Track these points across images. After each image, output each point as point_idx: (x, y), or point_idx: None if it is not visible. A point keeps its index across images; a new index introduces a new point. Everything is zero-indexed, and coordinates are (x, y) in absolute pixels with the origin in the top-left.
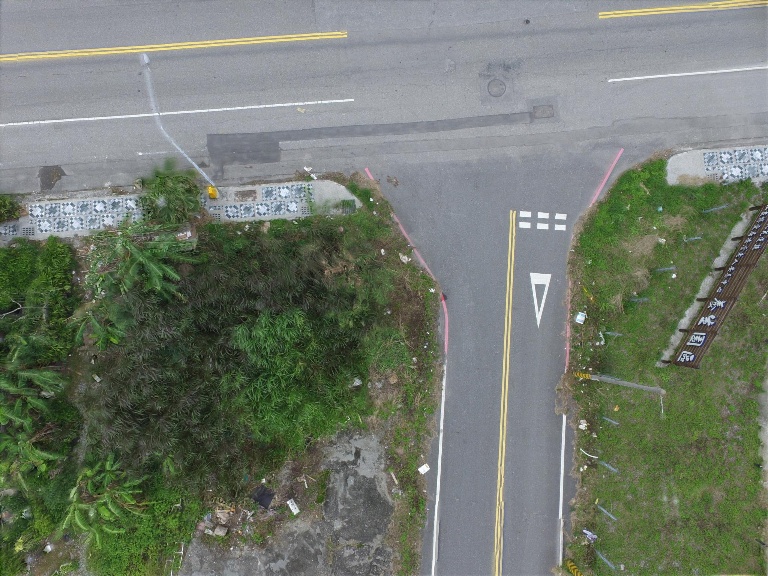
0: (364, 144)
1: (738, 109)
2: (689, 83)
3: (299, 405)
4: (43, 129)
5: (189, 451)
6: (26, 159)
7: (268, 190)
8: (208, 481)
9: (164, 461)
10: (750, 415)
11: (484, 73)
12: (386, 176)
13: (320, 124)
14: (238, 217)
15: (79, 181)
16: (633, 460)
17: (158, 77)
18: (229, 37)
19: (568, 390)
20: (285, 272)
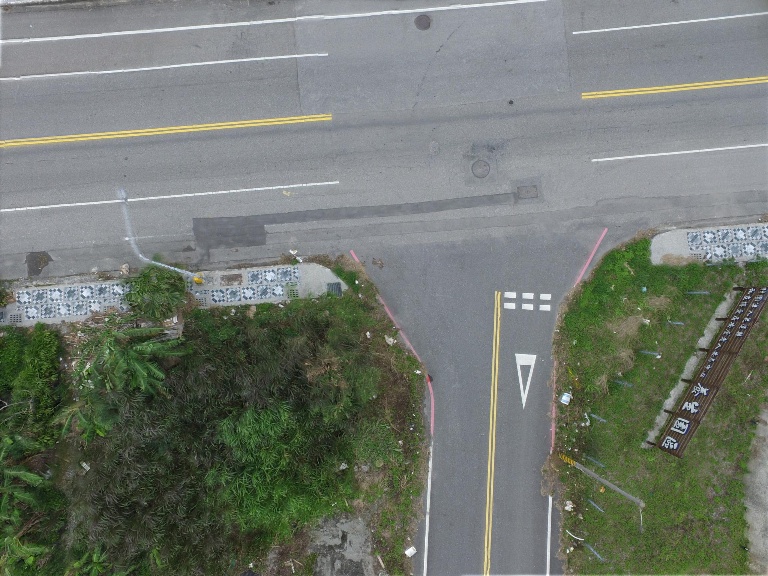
0: (349, 226)
1: (721, 188)
2: (672, 162)
3: (284, 498)
4: (30, 215)
5: (175, 544)
6: (13, 245)
7: (254, 274)
8: (194, 574)
9: (151, 553)
10: (735, 496)
11: (468, 154)
12: (371, 258)
13: (305, 207)
14: (224, 301)
15: (66, 267)
16: (619, 542)
17: (144, 162)
18: (214, 121)
19: (554, 471)
20: (270, 364)
